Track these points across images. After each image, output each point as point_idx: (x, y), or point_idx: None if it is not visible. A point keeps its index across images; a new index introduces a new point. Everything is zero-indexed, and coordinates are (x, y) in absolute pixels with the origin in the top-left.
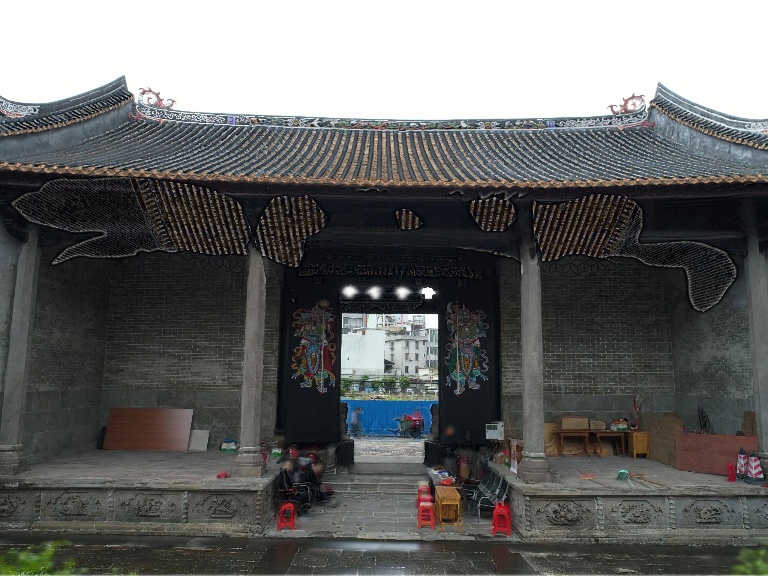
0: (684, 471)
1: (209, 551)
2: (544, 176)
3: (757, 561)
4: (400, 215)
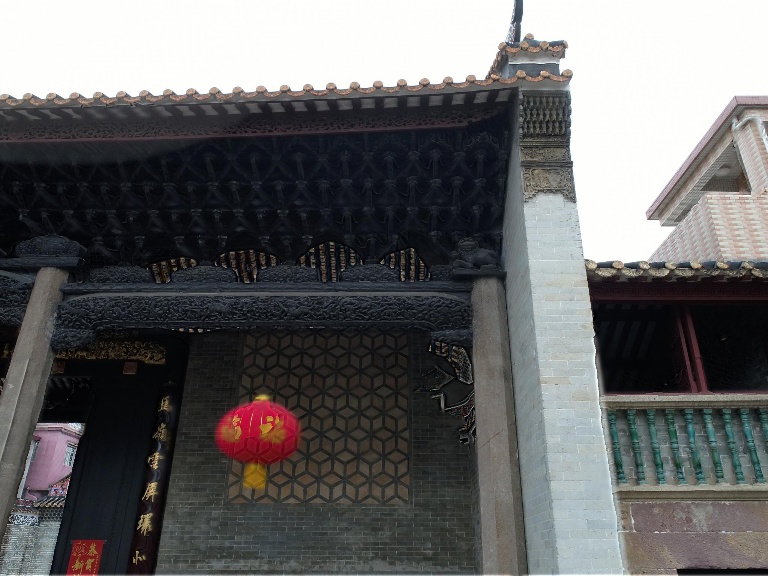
0: None
1: None
2: None
3: None
4: None
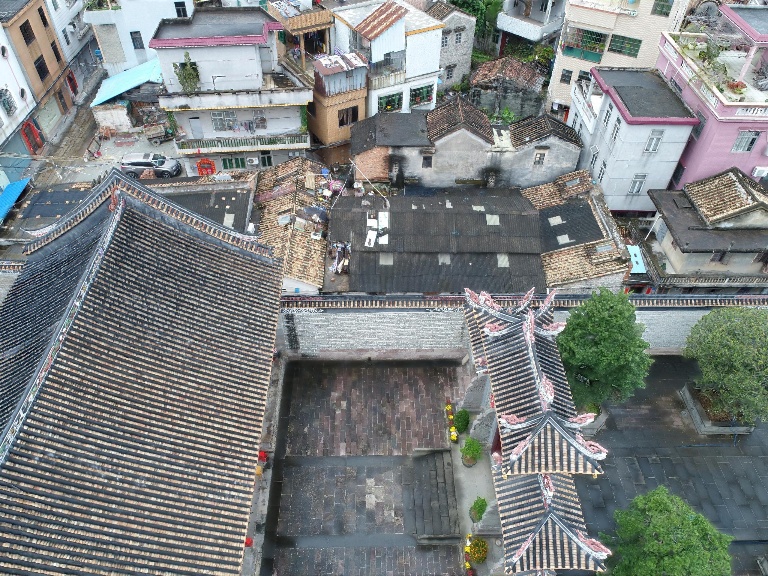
0: None
1: (278, 572)
2: (245, 346)
3: (298, 389)
4: (0, 383)
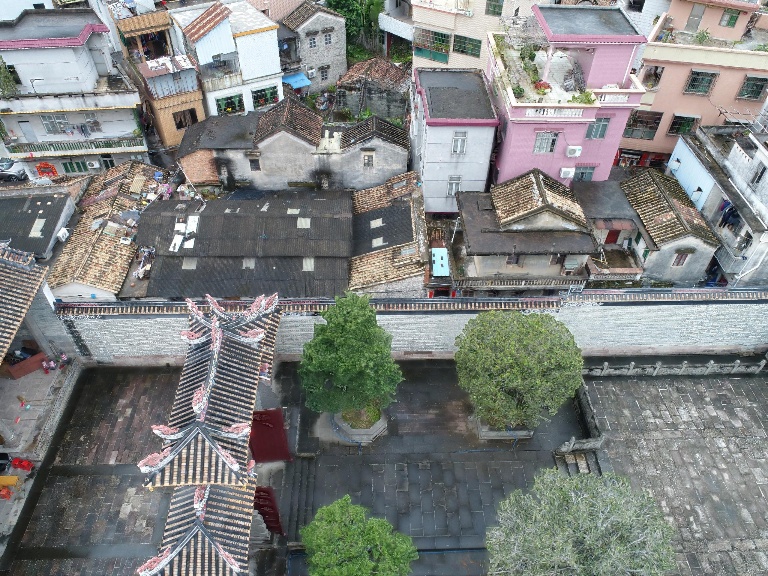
0: (20, 378)
1: None
2: None
3: (86, 396)
4: None
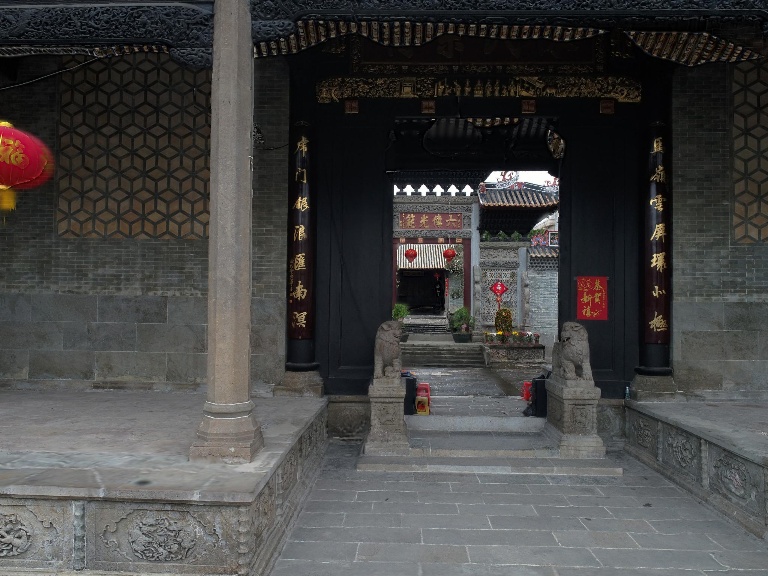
0: None
1: None
2: None
3: None
4: None
